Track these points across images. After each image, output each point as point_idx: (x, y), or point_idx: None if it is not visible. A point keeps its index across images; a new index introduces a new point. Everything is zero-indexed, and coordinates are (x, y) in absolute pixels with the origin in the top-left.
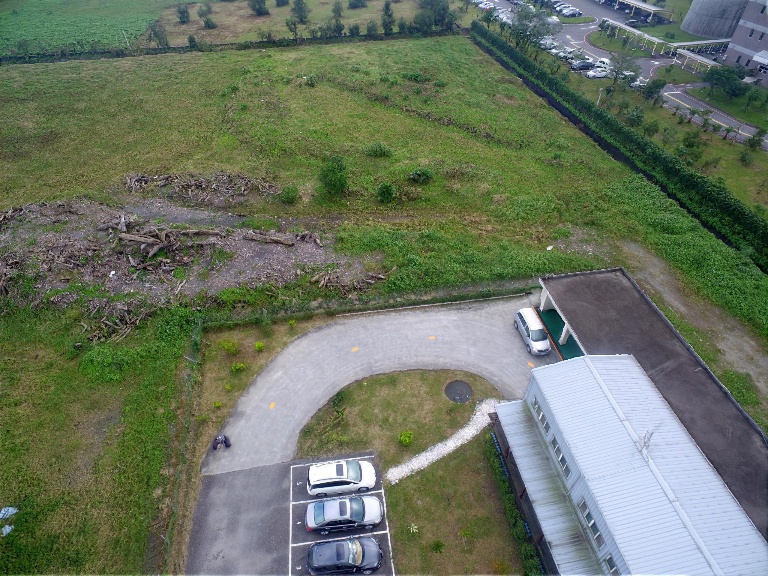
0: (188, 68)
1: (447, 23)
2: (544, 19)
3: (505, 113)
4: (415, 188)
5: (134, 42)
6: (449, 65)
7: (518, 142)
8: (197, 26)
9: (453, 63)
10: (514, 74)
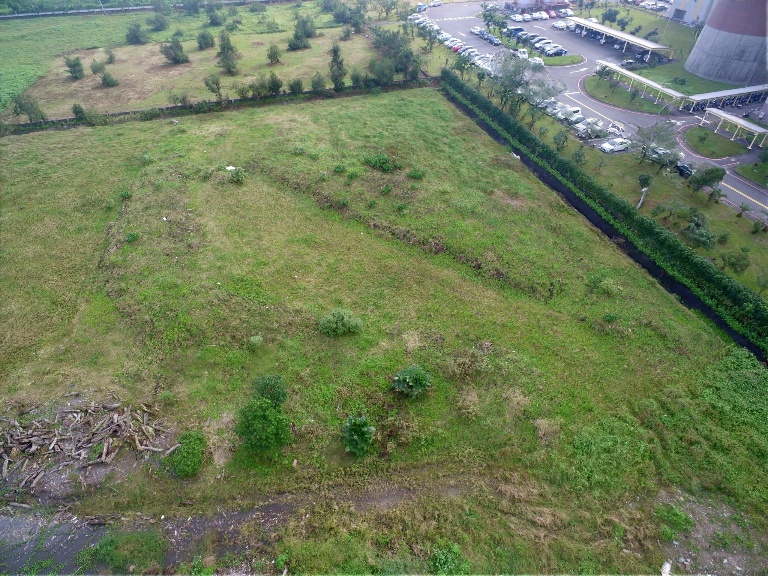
0: (66, 157)
1: (411, 72)
2: (539, 74)
3: (515, 228)
4: (406, 417)
5: (0, 113)
6: (423, 139)
7: (546, 286)
8: (93, 83)
9: (427, 135)
10: (507, 147)
